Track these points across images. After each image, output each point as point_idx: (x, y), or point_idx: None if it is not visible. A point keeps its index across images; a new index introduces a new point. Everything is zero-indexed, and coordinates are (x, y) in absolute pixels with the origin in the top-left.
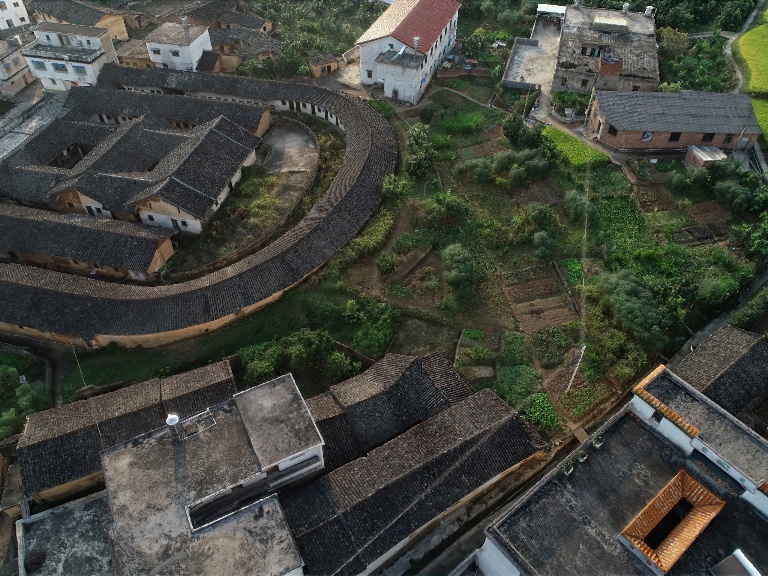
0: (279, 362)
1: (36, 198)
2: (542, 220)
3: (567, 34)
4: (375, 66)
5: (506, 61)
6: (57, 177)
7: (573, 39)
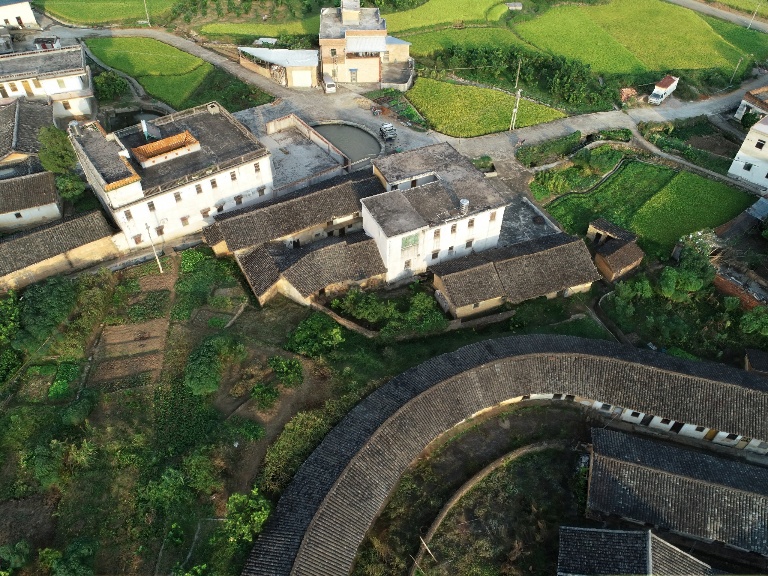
0: None
1: None
2: None
3: None
4: None
5: None
6: None
7: None
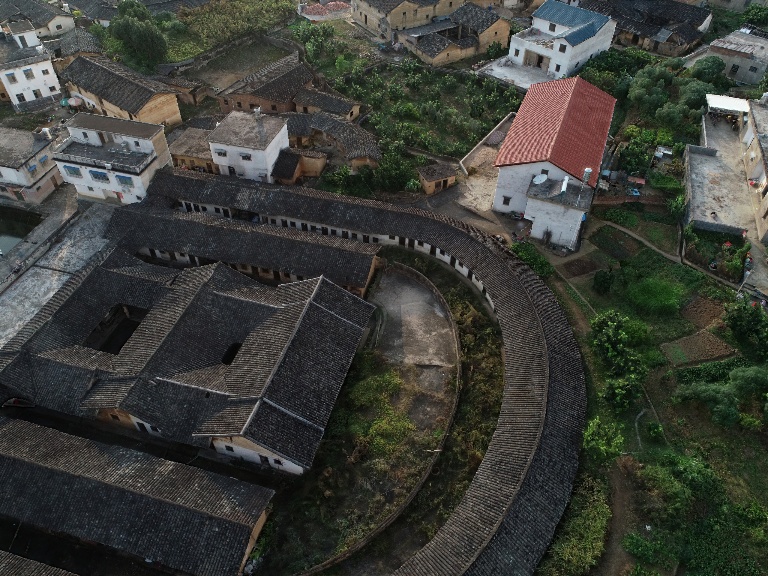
0: None
1: (67, 408)
2: None
3: None
4: (516, 193)
5: (678, 178)
6: (97, 374)
7: None
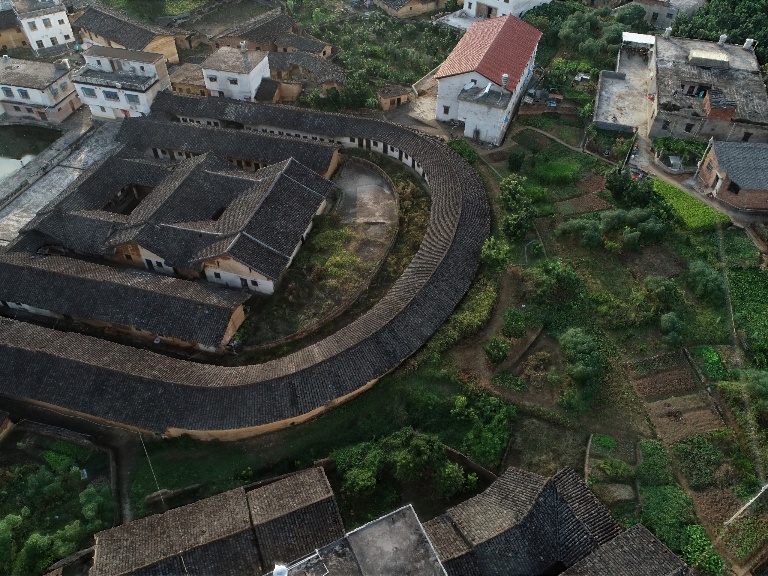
0: (380, 470)
1: (91, 249)
2: (667, 297)
3: (662, 69)
4: (453, 102)
5: (592, 96)
6: (114, 225)
7: (670, 75)
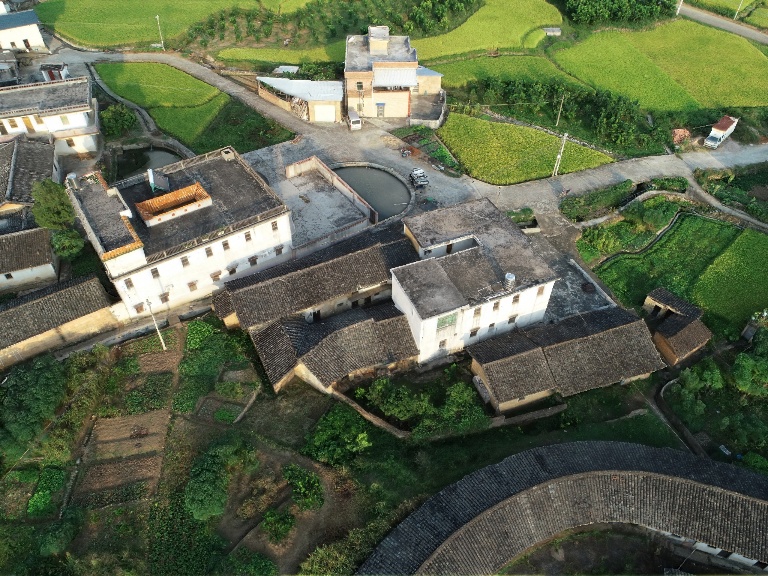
0: None
1: None
2: None
3: None
4: None
5: None
6: None
7: None
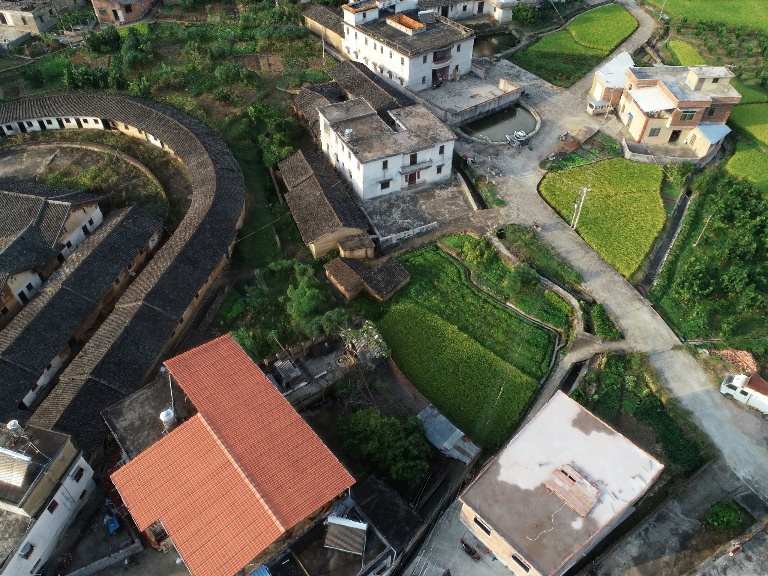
0: None
1: None
2: None
3: None
4: None
5: None
6: None
7: None
